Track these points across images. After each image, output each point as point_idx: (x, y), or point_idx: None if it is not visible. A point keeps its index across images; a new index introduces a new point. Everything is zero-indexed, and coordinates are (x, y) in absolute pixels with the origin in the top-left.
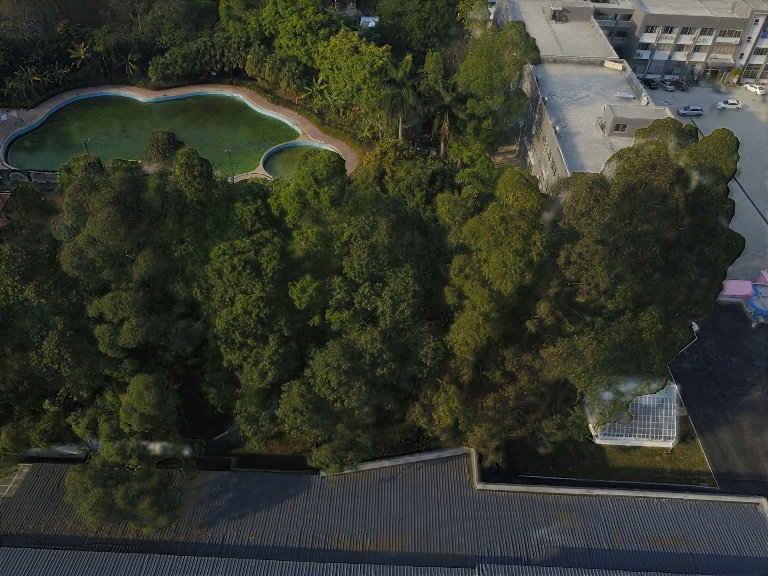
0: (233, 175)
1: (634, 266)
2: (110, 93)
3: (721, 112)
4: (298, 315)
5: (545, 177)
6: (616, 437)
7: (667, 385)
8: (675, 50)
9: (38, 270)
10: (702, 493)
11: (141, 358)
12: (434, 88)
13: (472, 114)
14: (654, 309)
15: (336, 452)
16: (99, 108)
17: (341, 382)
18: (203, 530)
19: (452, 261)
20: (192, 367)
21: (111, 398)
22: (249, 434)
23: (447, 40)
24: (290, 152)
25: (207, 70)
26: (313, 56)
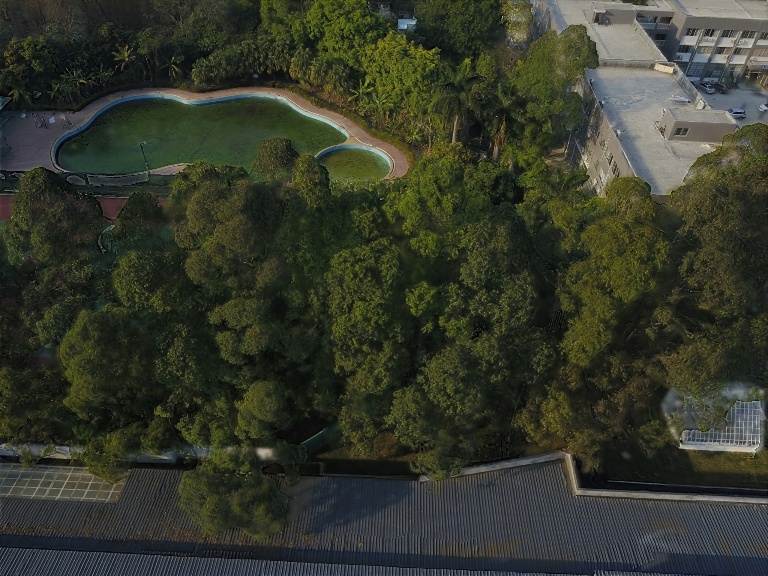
0: None
1: (747, 273)
2: (154, 95)
3: (763, 115)
4: (412, 322)
5: (605, 181)
6: (700, 442)
7: None
8: (715, 53)
9: (164, 277)
10: None
11: (259, 365)
12: (492, 92)
13: (532, 118)
14: (766, 316)
15: (442, 458)
16: (144, 111)
17: (458, 389)
18: (311, 536)
19: (568, 268)
20: (303, 373)
21: (223, 404)
22: (355, 440)
23: (490, 43)
24: (339, 155)
25: (250, 72)
26: (360, 59)
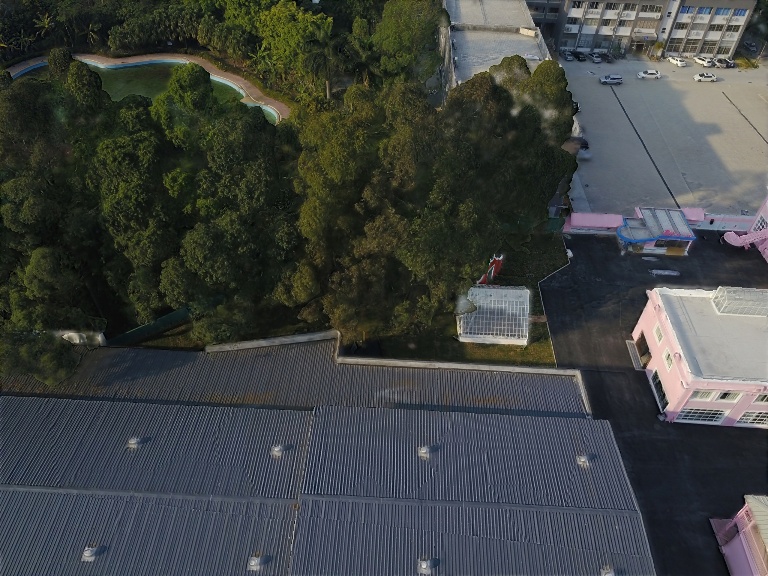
0: None
1: (453, 165)
2: None
3: (641, 81)
4: (174, 204)
5: None
6: (476, 335)
7: (521, 290)
8: (602, 25)
9: None
10: (527, 366)
11: (41, 235)
12: (354, 48)
13: (385, 70)
14: (470, 201)
15: (213, 325)
16: None
17: (206, 256)
18: (99, 388)
19: (299, 158)
20: (88, 249)
21: (20, 273)
22: (140, 309)
23: None
24: None
25: (163, 40)
26: (256, 24)
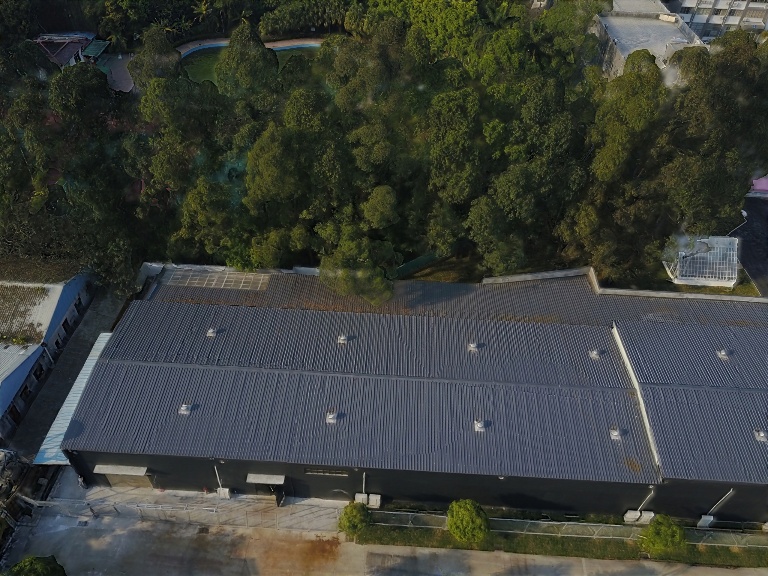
0: None
1: (723, 118)
2: (226, 44)
3: None
4: (485, 150)
5: None
6: (691, 277)
7: (730, 238)
8: (713, 14)
9: (321, 106)
10: (764, 297)
11: (380, 175)
12: (524, 30)
13: (558, 50)
14: (736, 150)
15: (502, 257)
16: (220, 56)
17: (519, 194)
18: (408, 310)
19: (596, 111)
20: (407, 189)
21: (350, 209)
22: (440, 243)
23: (517, 1)
24: None
25: (308, 26)
26: (408, 11)
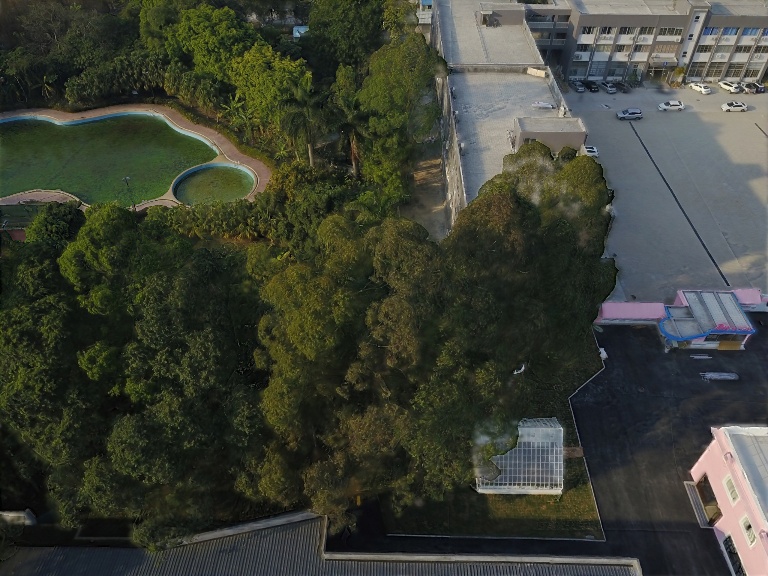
0: (141, 202)
1: (467, 318)
2: (26, 117)
3: (662, 114)
4: (96, 385)
5: (454, 196)
6: (499, 486)
7: (552, 428)
8: (615, 51)
9: None
10: (569, 556)
11: None
12: (337, 106)
13: (374, 133)
14: (491, 365)
15: (159, 528)
16: (13, 133)
17: (139, 460)
18: None
19: None
20: None
21: None
22: (63, 512)
23: (373, 50)
24: (204, 174)
25: (127, 89)
26: (228, 73)
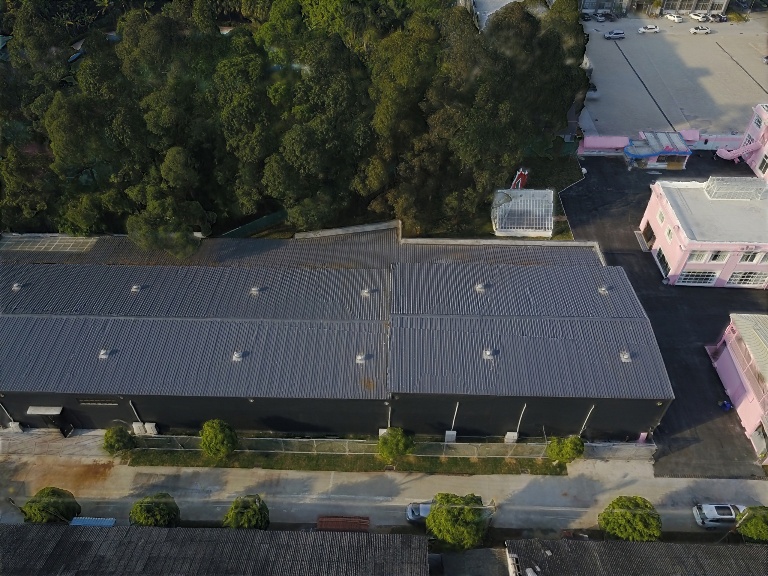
0: None
1: (493, 73)
2: None
3: (641, 36)
4: (274, 111)
5: None
6: (510, 229)
7: (546, 191)
8: None
9: (108, 75)
10: (554, 240)
11: (173, 138)
12: (389, 7)
13: None
14: (507, 102)
15: (303, 212)
16: None
17: (302, 150)
18: (216, 263)
19: (372, 71)
20: (206, 151)
21: (154, 172)
22: (245, 201)
23: None
24: None
25: None
26: None
